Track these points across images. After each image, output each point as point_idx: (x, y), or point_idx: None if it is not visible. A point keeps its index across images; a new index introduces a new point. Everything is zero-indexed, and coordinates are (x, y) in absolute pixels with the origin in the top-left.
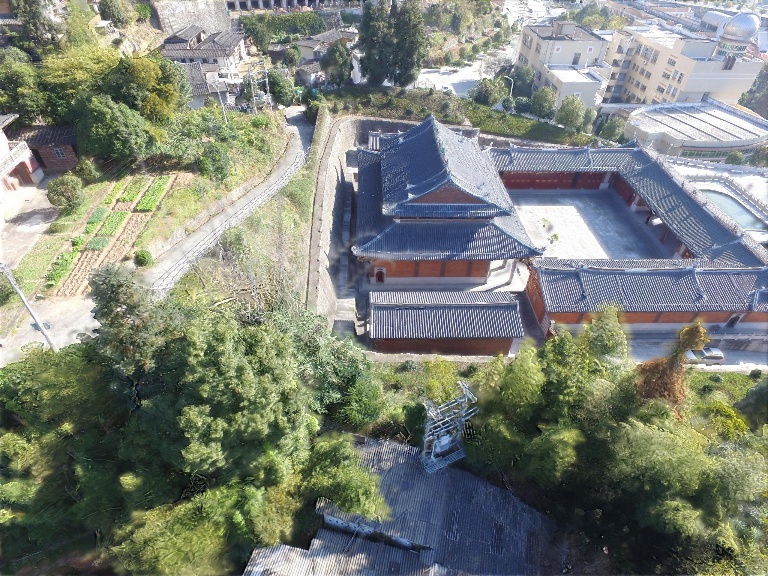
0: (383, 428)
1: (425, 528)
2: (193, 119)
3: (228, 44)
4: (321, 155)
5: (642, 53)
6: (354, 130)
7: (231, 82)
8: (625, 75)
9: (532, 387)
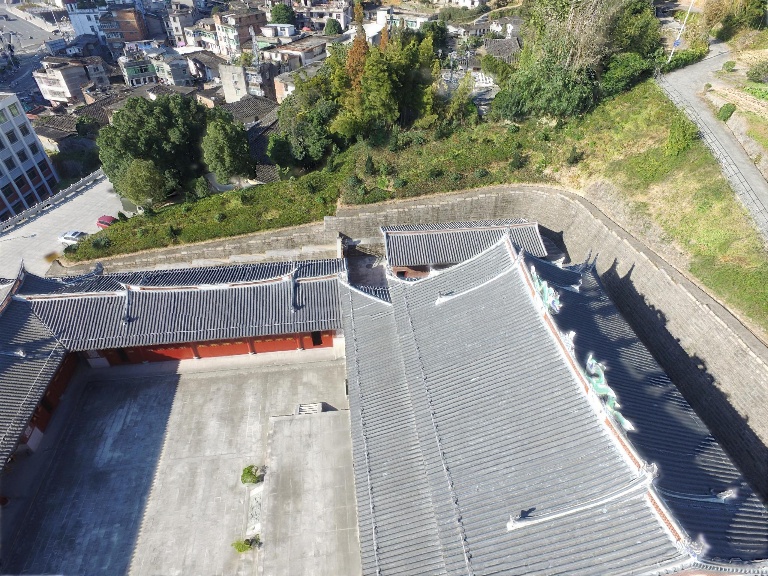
0: None
1: None
2: None
3: None
4: None
5: None
6: None
7: None
8: None
9: None
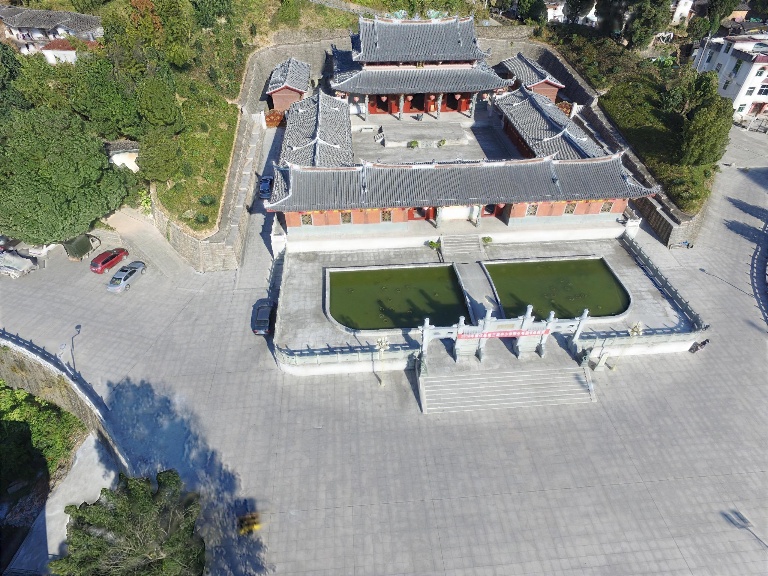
0: None
1: None
2: None
3: None
4: None
5: None
6: (538, 57)
7: (590, 18)
8: None
9: None
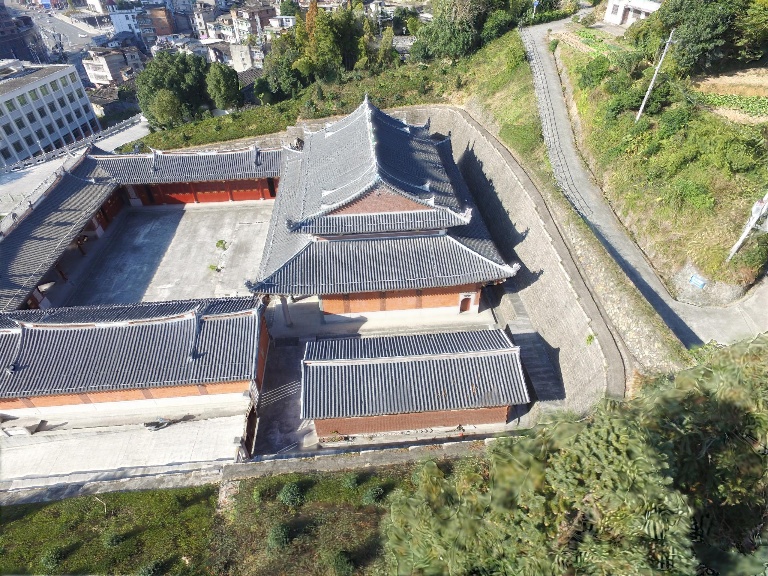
0: None
1: None
2: None
3: None
4: (552, 211)
5: None
6: None
7: None
8: None
9: None
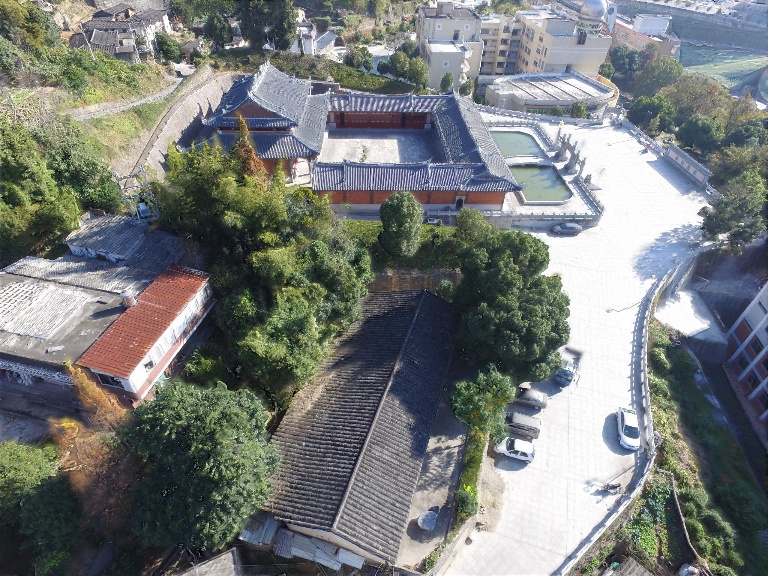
0: (125, 215)
1: (121, 248)
2: (63, 53)
3: (149, 18)
4: (185, 93)
5: (526, 33)
6: None
7: None
8: (517, 53)
9: (173, 162)
